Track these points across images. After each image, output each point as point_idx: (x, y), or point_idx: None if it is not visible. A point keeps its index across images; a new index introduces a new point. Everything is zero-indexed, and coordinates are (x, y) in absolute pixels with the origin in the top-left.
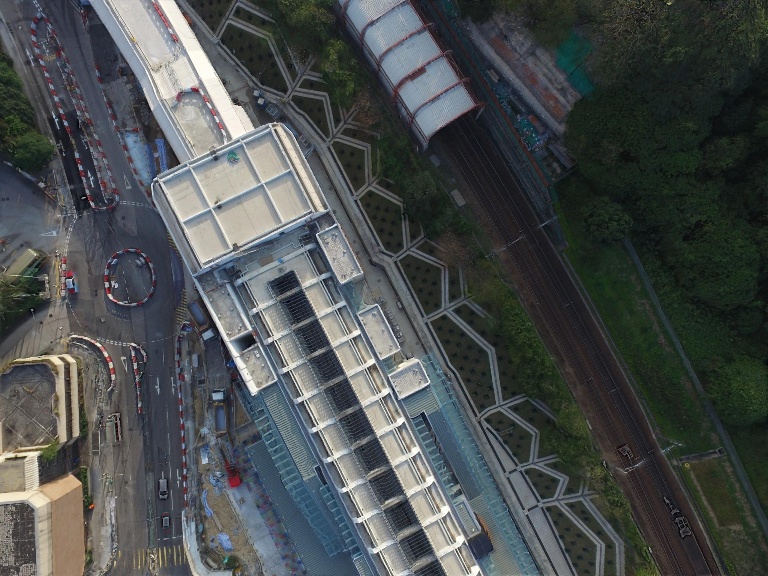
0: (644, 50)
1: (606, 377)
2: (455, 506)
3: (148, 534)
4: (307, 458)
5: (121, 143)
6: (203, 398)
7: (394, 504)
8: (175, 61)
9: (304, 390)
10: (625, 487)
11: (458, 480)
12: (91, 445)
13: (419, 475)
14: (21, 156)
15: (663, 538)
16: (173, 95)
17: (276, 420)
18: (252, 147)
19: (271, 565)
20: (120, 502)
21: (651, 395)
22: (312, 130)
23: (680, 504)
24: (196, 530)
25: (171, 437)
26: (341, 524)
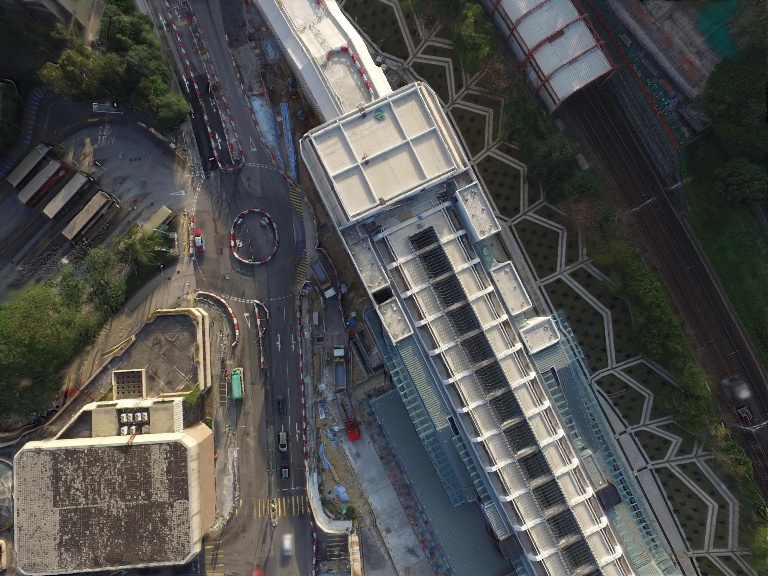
0: None
1: (726, 340)
2: (583, 459)
3: (268, 484)
4: (440, 409)
5: (249, 106)
6: (321, 355)
7: (527, 454)
8: (319, 22)
9: (440, 342)
10: (743, 448)
11: None
12: (218, 396)
13: (551, 427)
14: (165, 114)
15: None
16: (322, 54)
17: (411, 371)
18: (398, 105)
19: (385, 518)
20: (242, 453)
21: None
22: None
23: None
24: (316, 481)
25: (291, 392)
26: (472, 473)
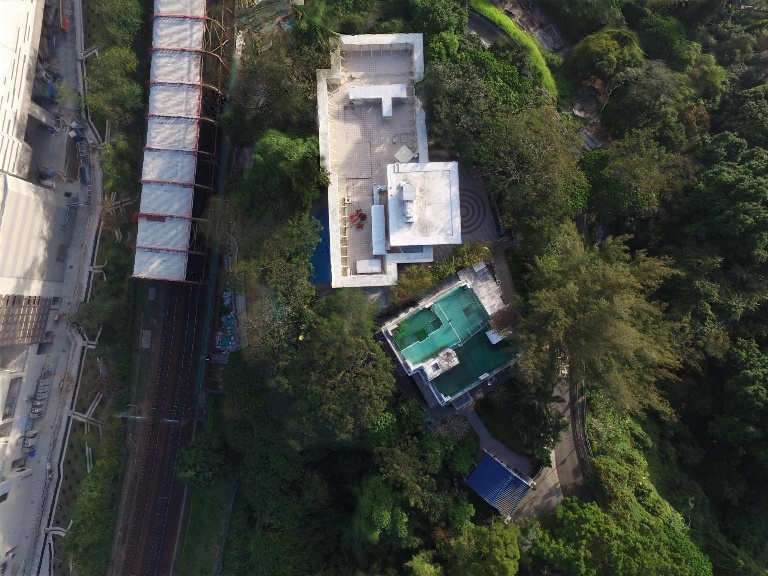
0: (263, 359)
1: None
2: None
3: None
4: None
5: None
6: None
7: None
8: None
9: None
10: None
11: None
12: None
13: None
14: None
15: None
16: None
17: None
18: None
19: None
20: None
21: None
22: (100, 187)
23: None
24: None
25: None
26: None
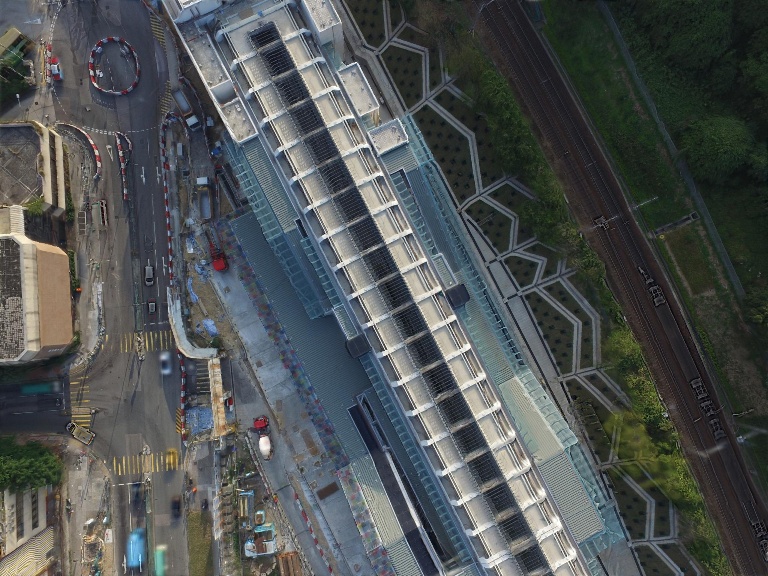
0: None
1: (583, 151)
2: (433, 260)
3: (135, 319)
4: (288, 212)
5: None
6: (188, 189)
7: (372, 250)
8: None
9: (284, 141)
10: (601, 258)
11: (437, 251)
12: (77, 225)
13: (397, 224)
14: None
15: (638, 307)
16: None
17: (257, 173)
18: None
19: (256, 352)
20: (107, 287)
21: (627, 168)
22: None
23: (654, 274)
24: (181, 311)
25: (157, 225)
26: (321, 276)
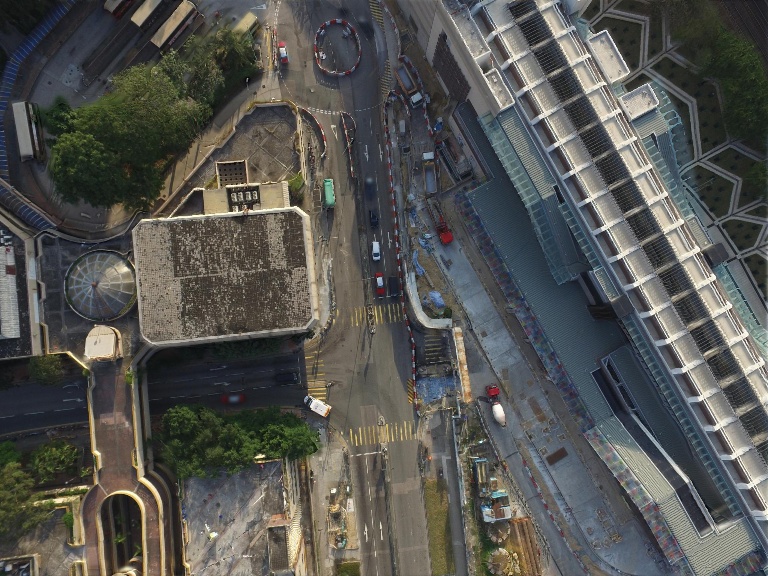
0: None
1: None
2: (687, 221)
3: (364, 293)
4: (545, 178)
5: None
6: (408, 165)
7: None
8: None
9: (543, 109)
10: None
11: None
12: (312, 203)
13: (657, 186)
14: None
15: None
16: None
17: (514, 142)
18: None
19: (480, 322)
20: (336, 263)
21: None
22: None
23: None
24: None
25: (381, 202)
26: (580, 240)
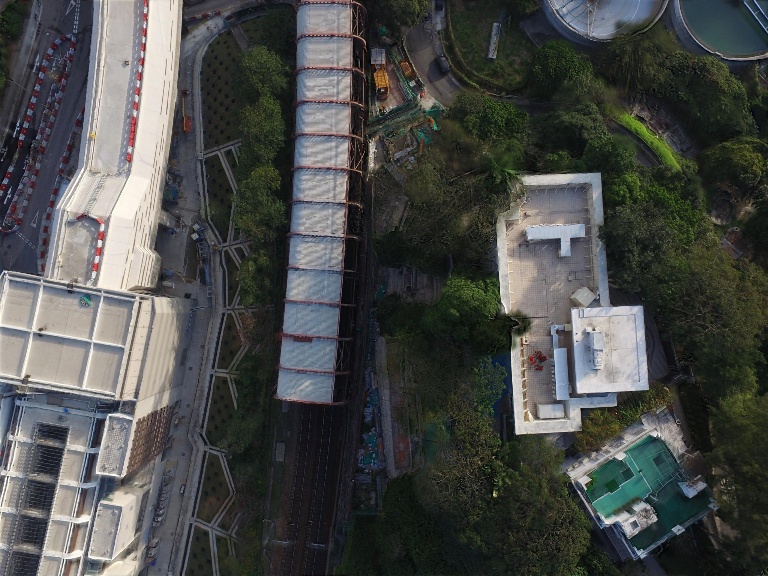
0: (451, 512)
1: None
2: None
3: None
4: None
5: (54, 186)
6: None
7: None
8: (115, 176)
9: None
10: None
11: None
12: None
13: None
14: None
15: None
16: (79, 211)
17: None
18: (110, 303)
19: None
20: None
21: None
22: (221, 289)
23: None
24: None
25: None
26: None
